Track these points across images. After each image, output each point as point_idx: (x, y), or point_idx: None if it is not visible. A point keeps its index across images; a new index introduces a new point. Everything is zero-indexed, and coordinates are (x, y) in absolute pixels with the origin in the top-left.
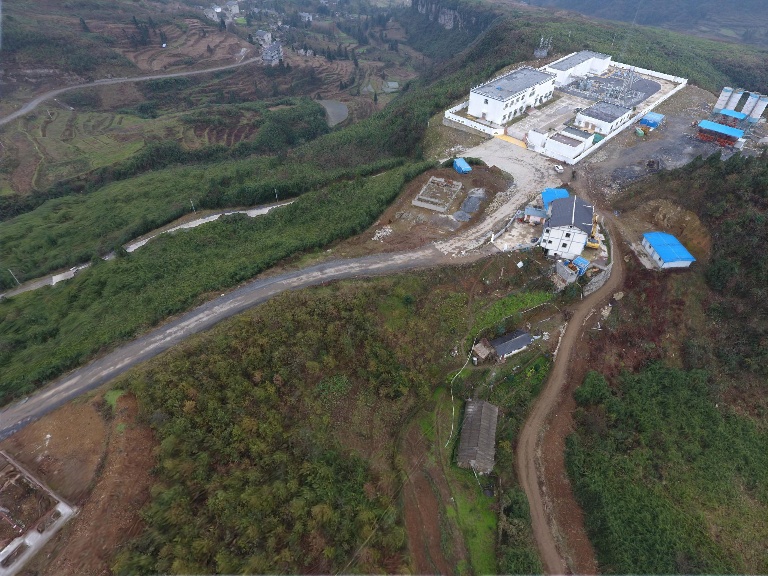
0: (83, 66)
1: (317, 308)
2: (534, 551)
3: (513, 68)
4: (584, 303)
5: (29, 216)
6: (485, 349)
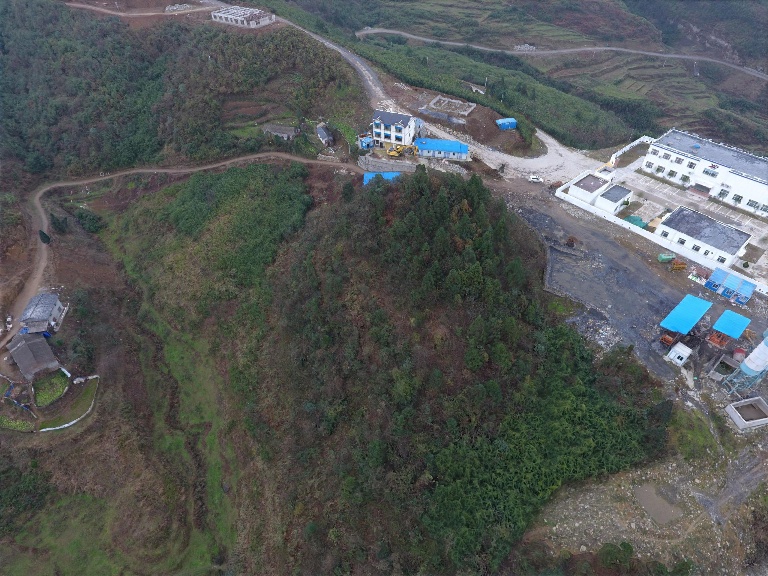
0: (750, 51)
1: (327, 57)
2: (230, 142)
3: None
4: (353, 165)
5: None
6: (321, 126)
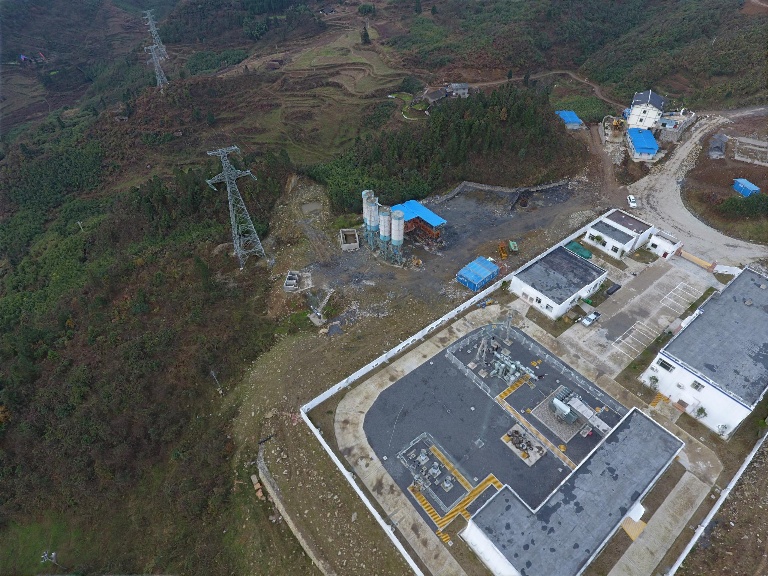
0: None
1: None
2: None
3: None
4: None
5: None
6: None
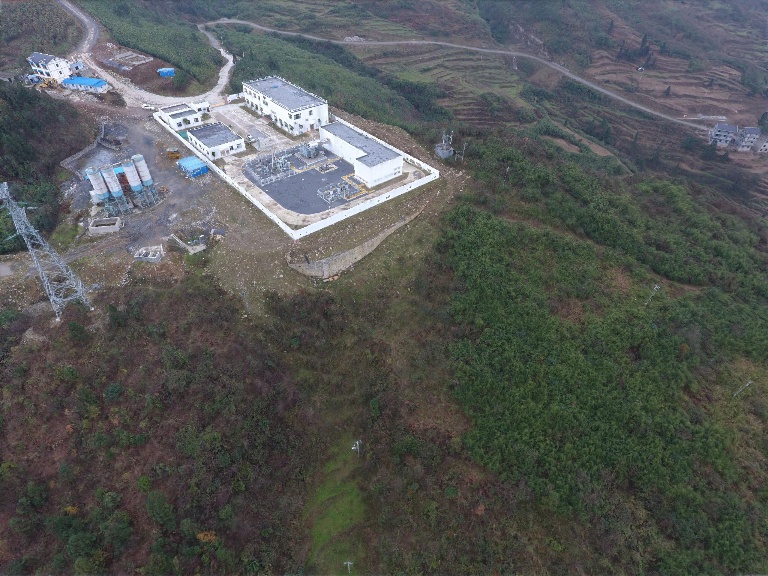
0: (555, 48)
1: None
2: None
3: (388, 128)
4: None
5: (307, 53)
6: None
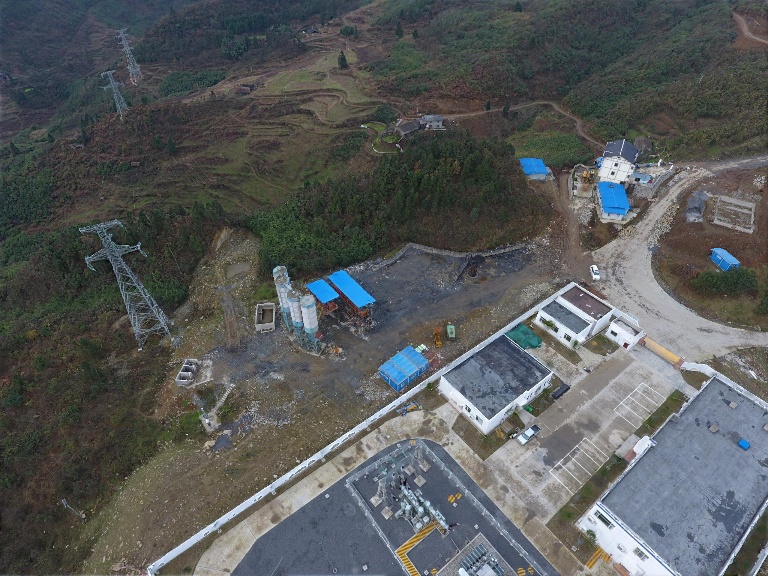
0: None
1: (763, 122)
2: None
3: None
4: None
5: None
6: None
